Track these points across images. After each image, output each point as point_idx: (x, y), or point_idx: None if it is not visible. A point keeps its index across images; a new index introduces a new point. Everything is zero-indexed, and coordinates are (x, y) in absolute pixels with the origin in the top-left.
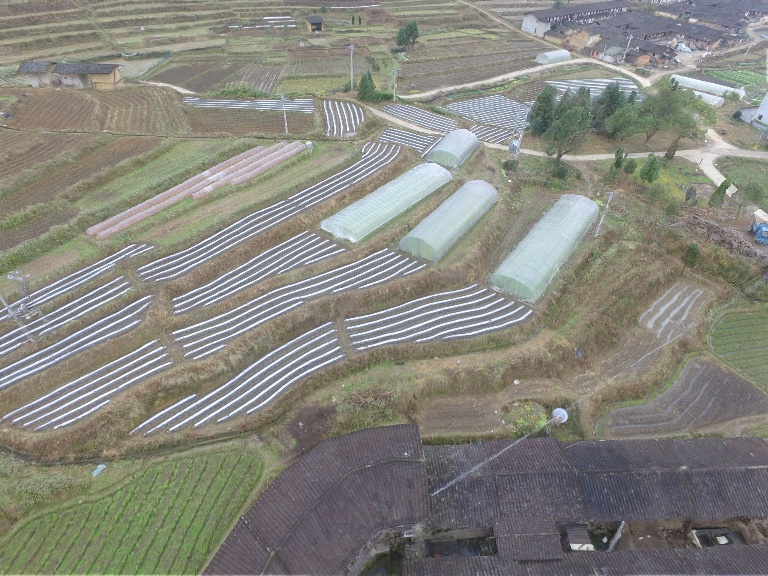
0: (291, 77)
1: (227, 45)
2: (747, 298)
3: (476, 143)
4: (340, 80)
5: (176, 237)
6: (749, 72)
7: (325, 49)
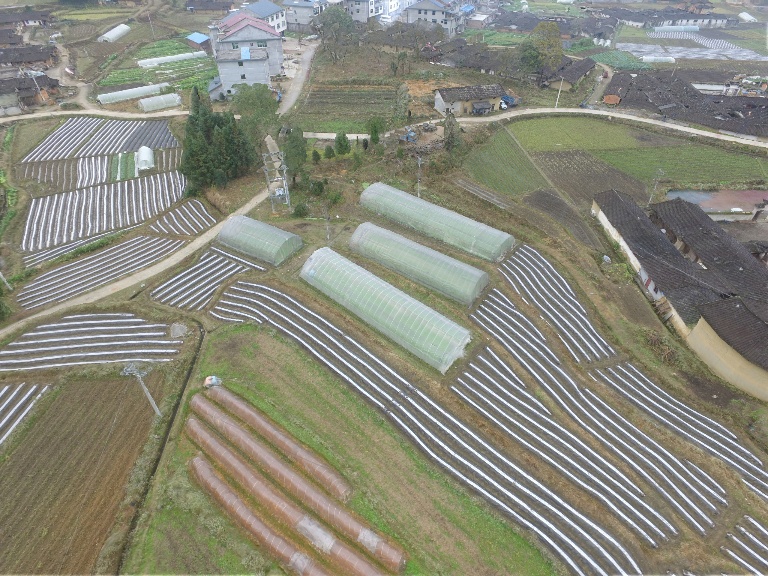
0: None
1: None
2: None
3: None
4: None
5: (529, 568)
6: (120, 71)
7: None
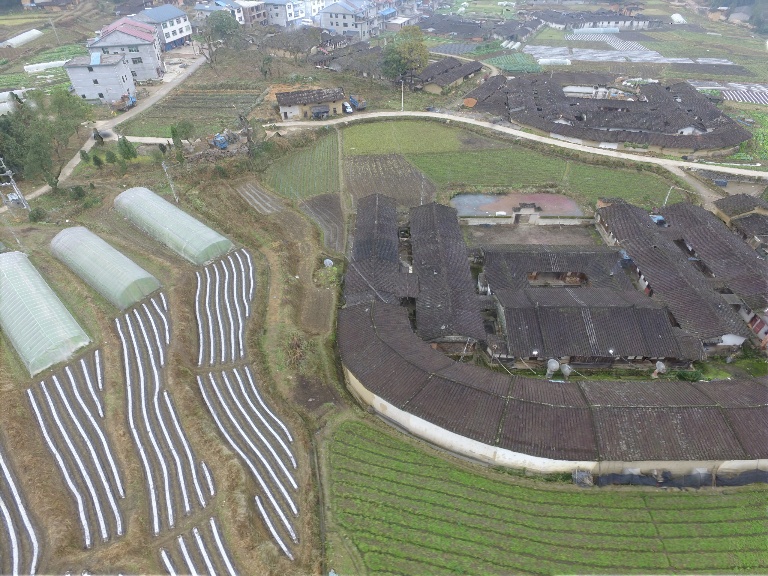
0: None
1: None
2: (261, 173)
3: None
4: None
5: None
6: (2, 76)
7: None
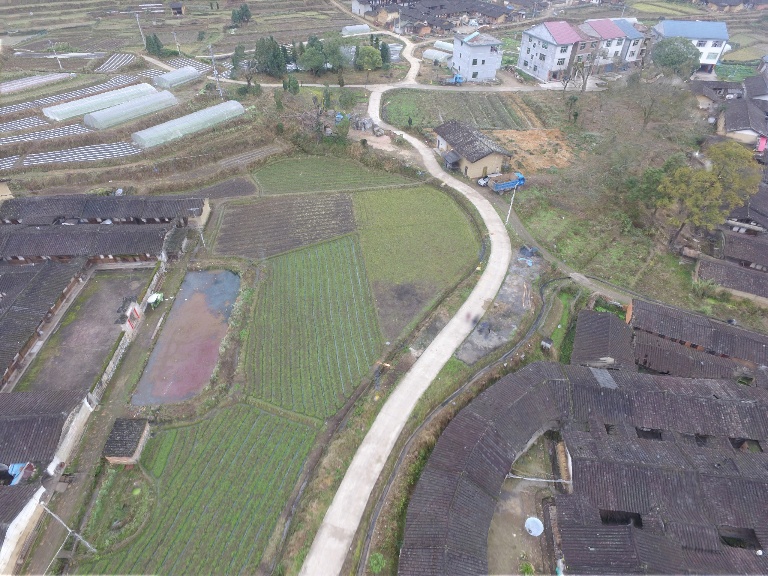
0: (129, 45)
1: (95, 25)
2: (305, 153)
3: (196, 75)
4: (167, 47)
5: None
6: (508, 39)
7: (173, 27)
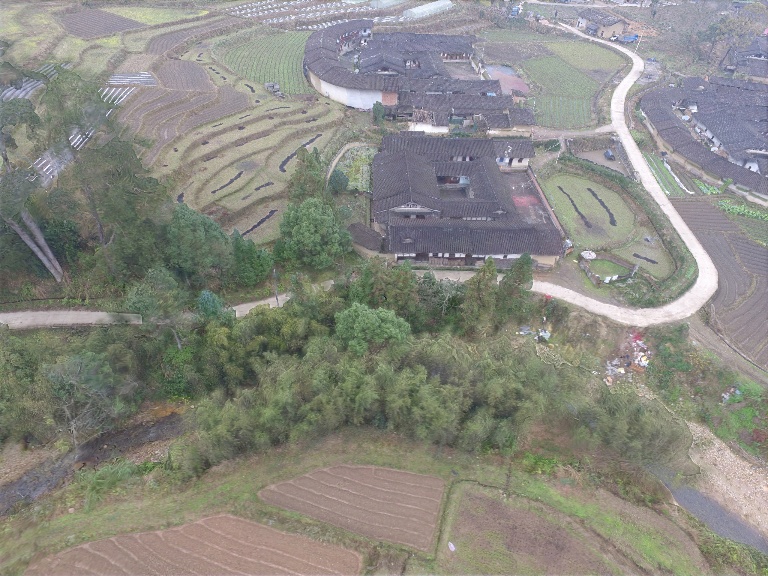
0: None
1: None
2: (500, 28)
3: None
4: None
5: None
6: None
7: None
